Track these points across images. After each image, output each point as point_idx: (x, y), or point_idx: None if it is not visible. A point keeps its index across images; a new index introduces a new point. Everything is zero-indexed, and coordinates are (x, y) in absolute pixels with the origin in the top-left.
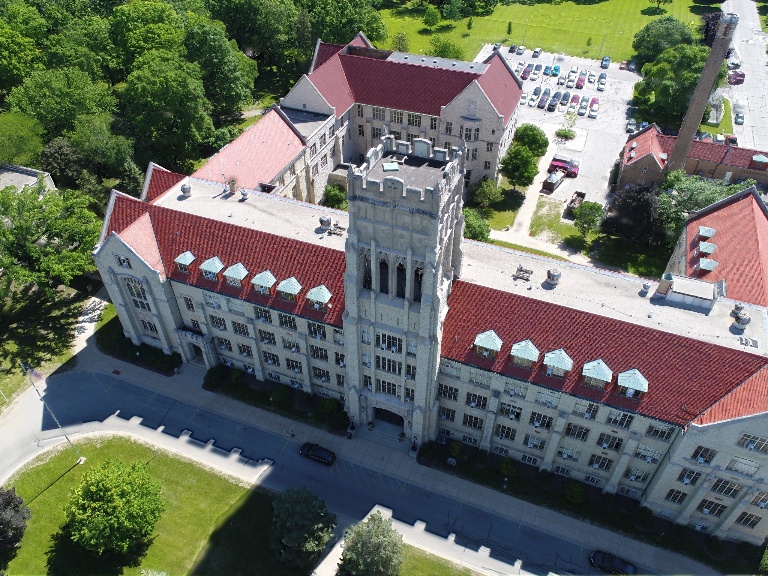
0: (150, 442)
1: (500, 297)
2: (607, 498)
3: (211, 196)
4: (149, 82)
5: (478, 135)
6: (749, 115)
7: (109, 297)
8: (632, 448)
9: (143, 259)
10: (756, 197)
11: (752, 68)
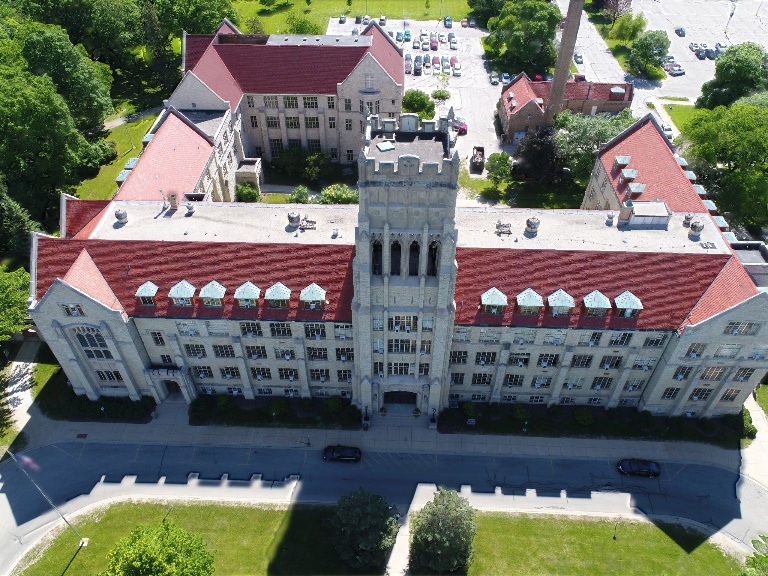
0: (156, 498)
1: (494, 254)
2: (613, 413)
3: (151, 217)
4: (4, 104)
5: (379, 107)
6: (584, 54)
7: (34, 357)
8: (632, 362)
9: (99, 302)
10: (653, 122)
11: None
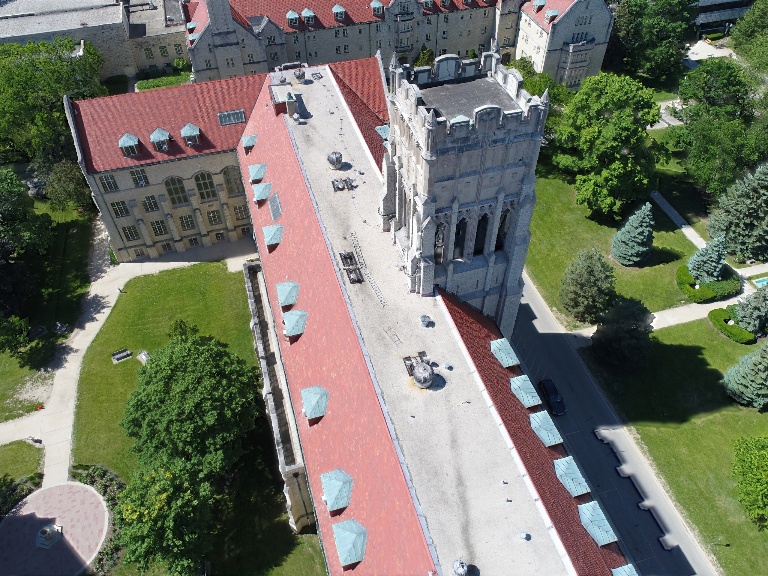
0: (715, 572)
1: None
2: None
3: None
4: None
5: None
6: None
7: None
8: None
9: None
10: None
11: None
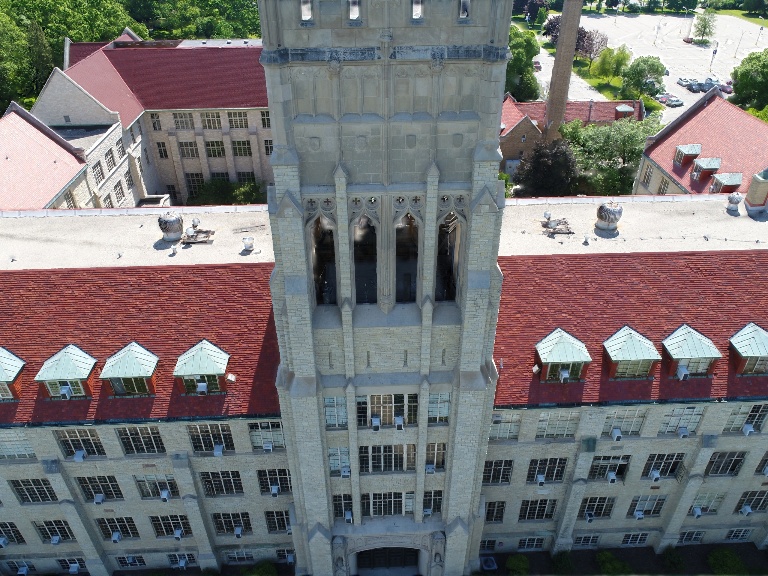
0: None
1: (553, 266)
2: None
3: None
4: None
5: None
6: None
7: None
8: None
9: None
10: None
11: (539, 59)
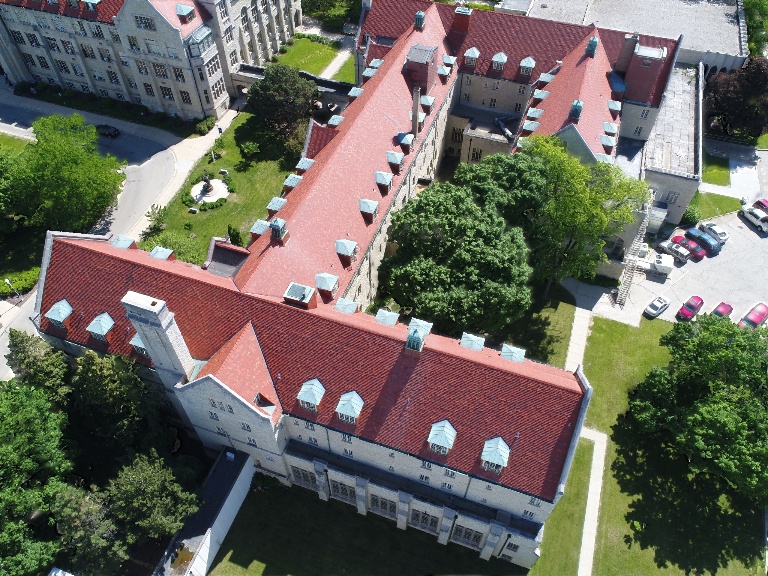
0: None
1: None
2: None
3: None
4: None
5: None
6: None
7: None
8: (113, 54)
9: None
10: None
11: None
